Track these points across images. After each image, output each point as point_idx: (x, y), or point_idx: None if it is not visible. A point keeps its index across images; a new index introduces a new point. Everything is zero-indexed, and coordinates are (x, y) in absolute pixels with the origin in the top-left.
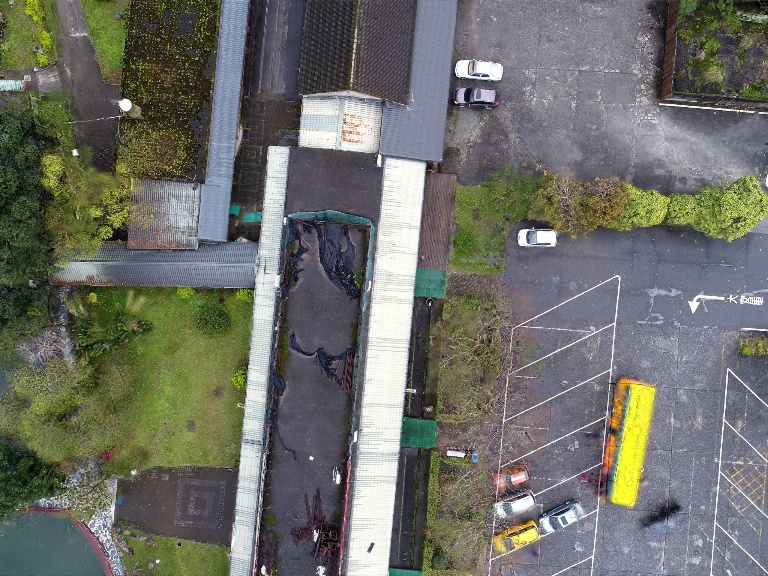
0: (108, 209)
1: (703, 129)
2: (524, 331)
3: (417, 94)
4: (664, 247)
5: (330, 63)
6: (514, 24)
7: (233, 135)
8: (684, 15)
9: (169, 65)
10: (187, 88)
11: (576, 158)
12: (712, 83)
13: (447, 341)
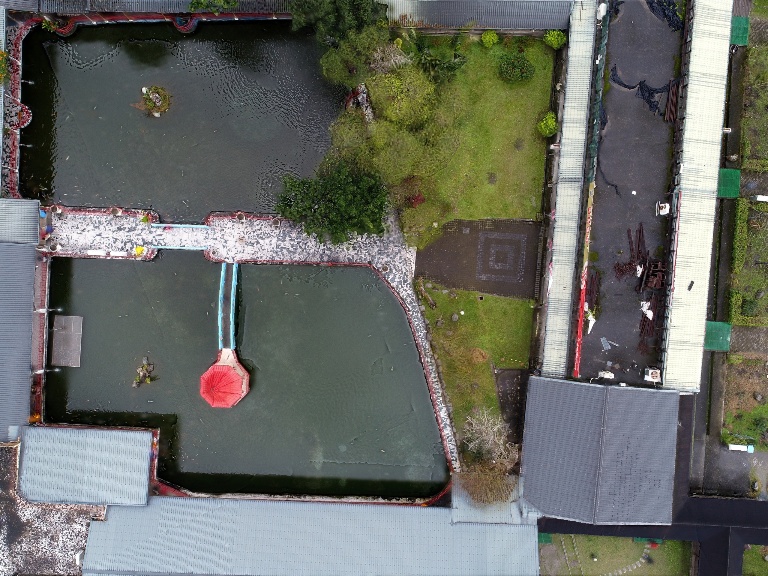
0: None
1: None
2: None
3: None
4: None
5: None
6: None
7: None
8: None
9: None
10: None
11: None
12: None
13: (750, 89)
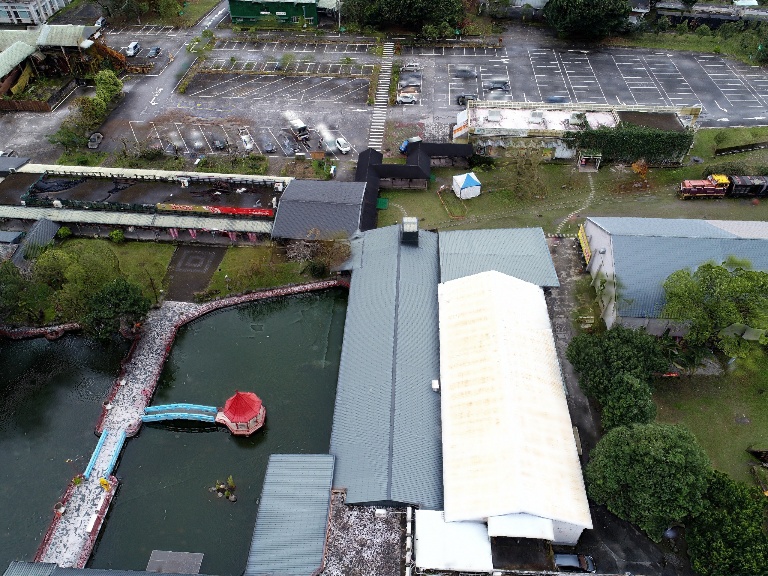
0: None
1: None
2: None
3: None
4: None
5: None
6: None
7: None
8: None
9: None
10: None
11: None
12: None
13: None
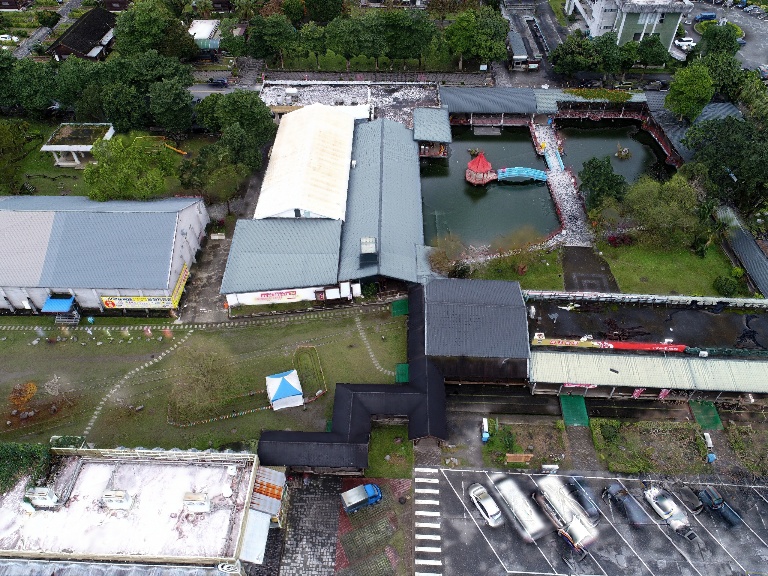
0: (767, 236)
1: None
2: None
3: None
4: None
5: None
6: None
7: None
8: None
9: None
10: None
11: None
12: None
13: None
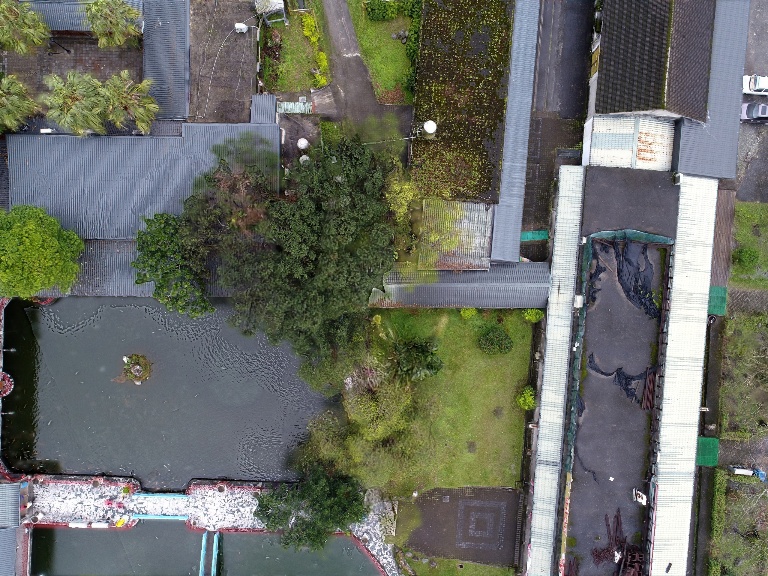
0: None
1: None
2: None
3: (712, 111)
4: None
5: (636, 82)
6: None
7: (524, 155)
8: None
9: (462, 85)
10: (480, 108)
11: None
12: None
13: None
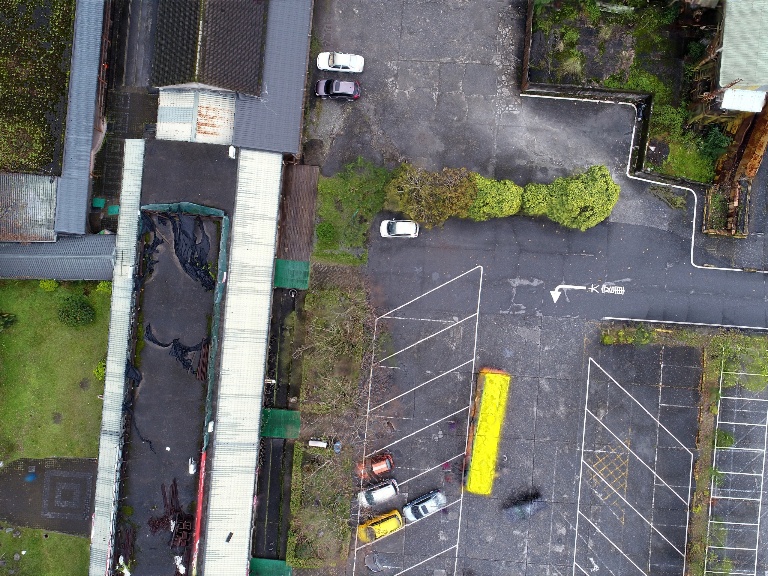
0: None
1: (564, 119)
2: (387, 322)
3: (271, 86)
4: (526, 237)
5: (179, 55)
6: (376, 16)
7: (90, 128)
8: (544, 6)
9: (24, 58)
10: (42, 81)
11: (438, 149)
12: (572, 74)
13: None
